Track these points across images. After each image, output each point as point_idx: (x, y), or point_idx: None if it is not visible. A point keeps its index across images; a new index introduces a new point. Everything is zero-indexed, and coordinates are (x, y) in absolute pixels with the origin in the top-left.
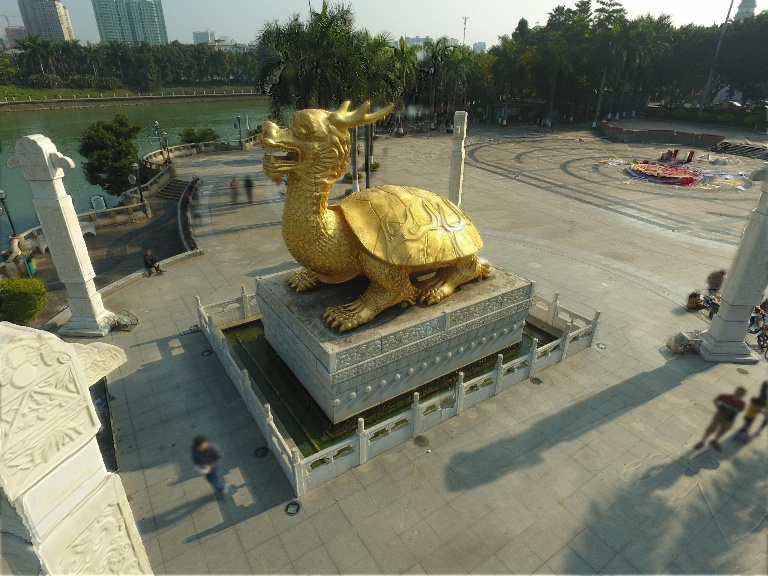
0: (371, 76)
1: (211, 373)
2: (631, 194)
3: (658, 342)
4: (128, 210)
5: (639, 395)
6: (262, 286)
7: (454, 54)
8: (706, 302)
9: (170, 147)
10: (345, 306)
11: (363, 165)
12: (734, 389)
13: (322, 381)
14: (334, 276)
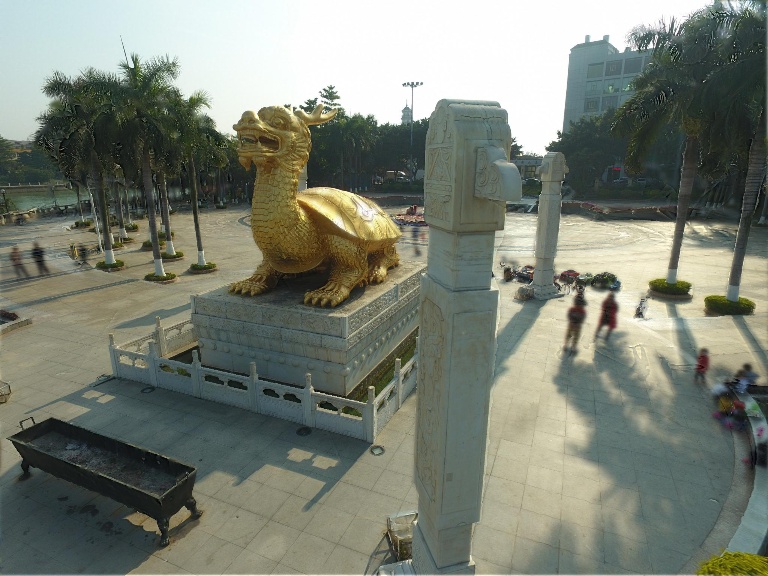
0: None
1: (175, 401)
2: (408, 233)
3: (508, 298)
4: None
5: (526, 323)
6: (207, 299)
7: None
8: (514, 273)
9: None
10: (320, 289)
11: None
12: (566, 309)
13: (328, 356)
14: (301, 265)
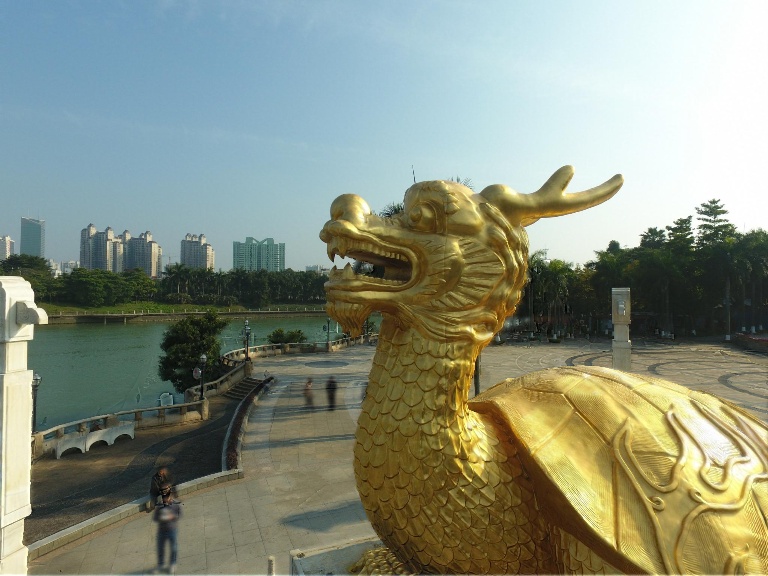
0: None
1: None
2: None
3: None
4: (182, 409)
5: None
6: None
7: (552, 265)
8: None
9: (255, 346)
10: None
11: None
12: None
13: None
14: None
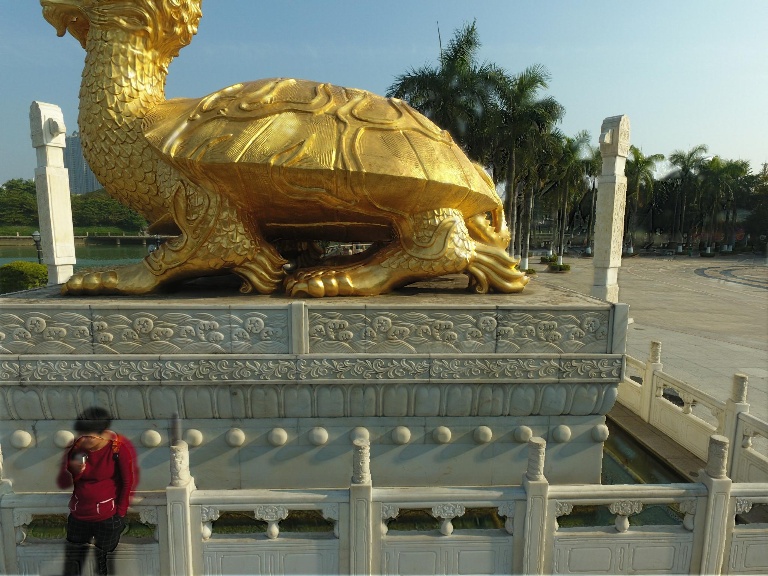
0: (517, 119)
1: None
2: None
3: None
4: None
5: None
6: None
7: (713, 163)
8: None
9: (362, 244)
10: None
11: (548, 266)
12: None
13: None
14: (156, 220)
